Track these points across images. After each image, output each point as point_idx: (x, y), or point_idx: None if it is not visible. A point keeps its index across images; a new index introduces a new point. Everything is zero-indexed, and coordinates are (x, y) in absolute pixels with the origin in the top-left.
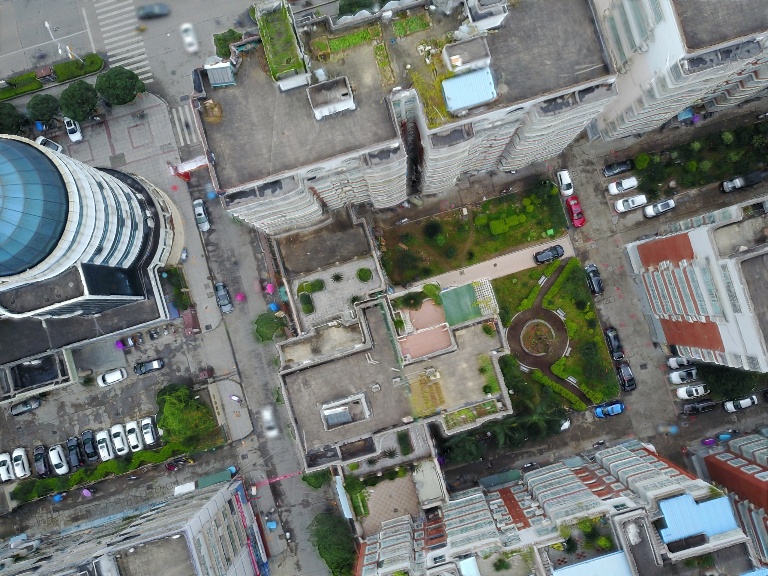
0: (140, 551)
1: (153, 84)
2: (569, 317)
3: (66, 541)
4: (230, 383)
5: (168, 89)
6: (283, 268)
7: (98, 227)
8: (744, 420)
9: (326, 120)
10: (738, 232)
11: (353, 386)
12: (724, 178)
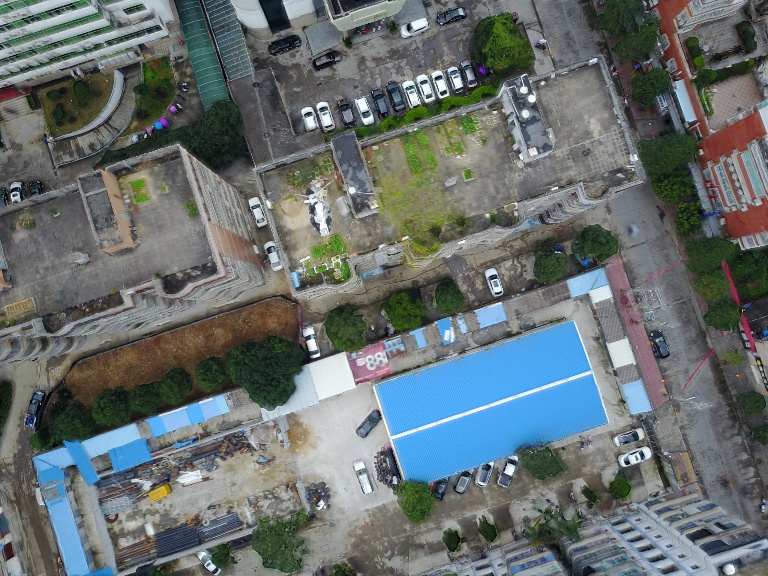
0: (551, 83)
1: None
2: None
3: None
4: (532, 32)
5: None
6: None
7: None
8: None
9: None
10: None
11: None
12: None
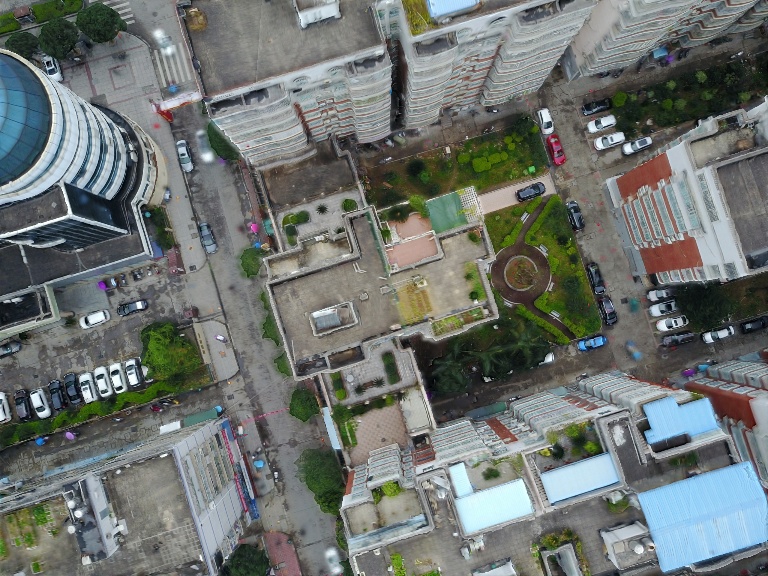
0: (127, 472)
1: (134, 25)
2: (551, 253)
3: (49, 480)
4: (215, 324)
5: (150, 31)
6: (268, 200)
7: (81, 146)
8: (721, 351)
9: (312, 28)
10: (714, 145)
11: (341, 295)
12: (699, 115)
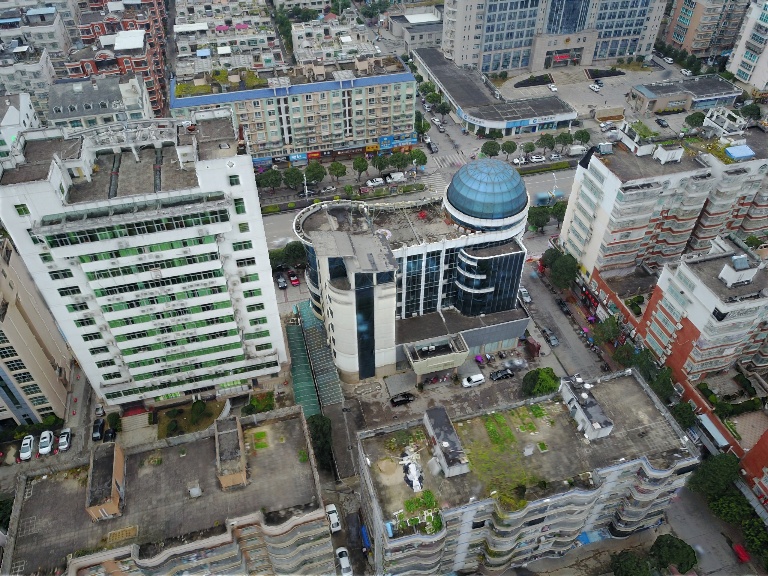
0: (599, 386)
1: None
2: None
3: None
4: None
5: None
6: None
7: None
8: None
9: (666, 165)
10: None
11: None
12: None
